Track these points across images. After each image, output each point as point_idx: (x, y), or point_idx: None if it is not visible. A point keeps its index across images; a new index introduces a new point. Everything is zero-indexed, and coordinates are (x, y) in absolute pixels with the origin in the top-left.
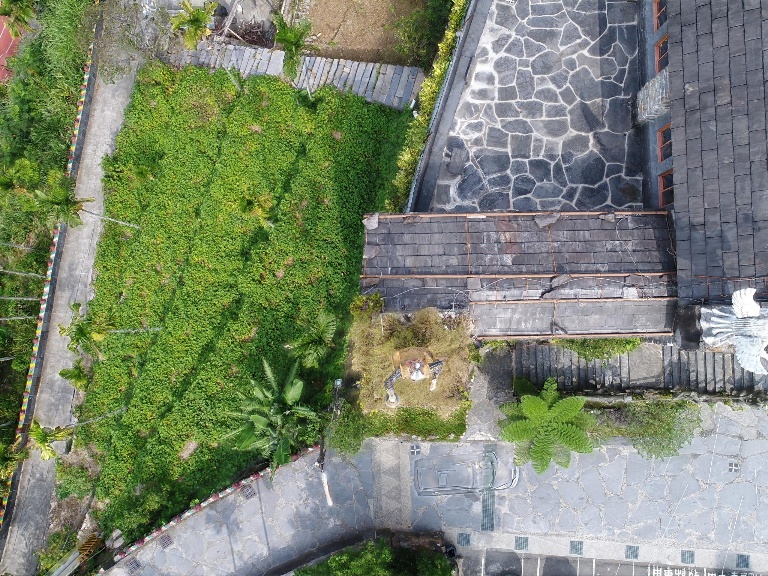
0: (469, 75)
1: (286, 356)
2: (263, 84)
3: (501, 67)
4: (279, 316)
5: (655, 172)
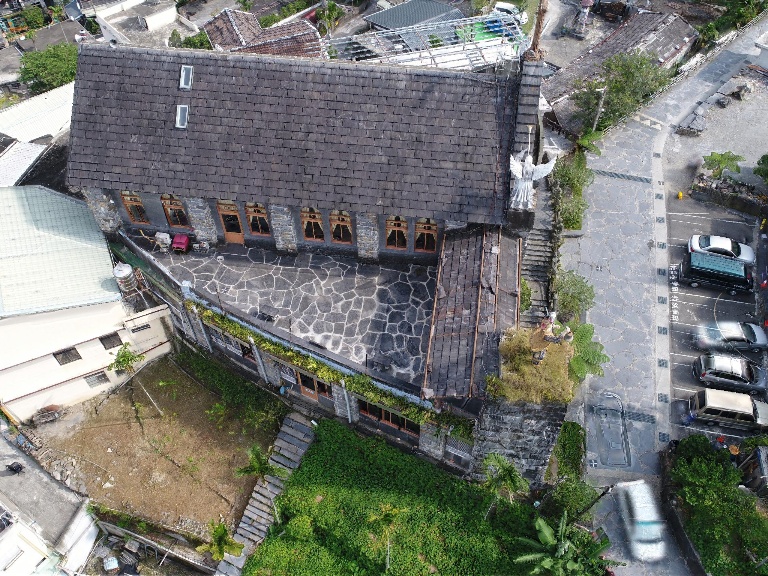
0: (323, 346)
1: (509, 571)
2: (252, 569)
3: (320, 330)
4: (472, 574)
5: (412, 253)
